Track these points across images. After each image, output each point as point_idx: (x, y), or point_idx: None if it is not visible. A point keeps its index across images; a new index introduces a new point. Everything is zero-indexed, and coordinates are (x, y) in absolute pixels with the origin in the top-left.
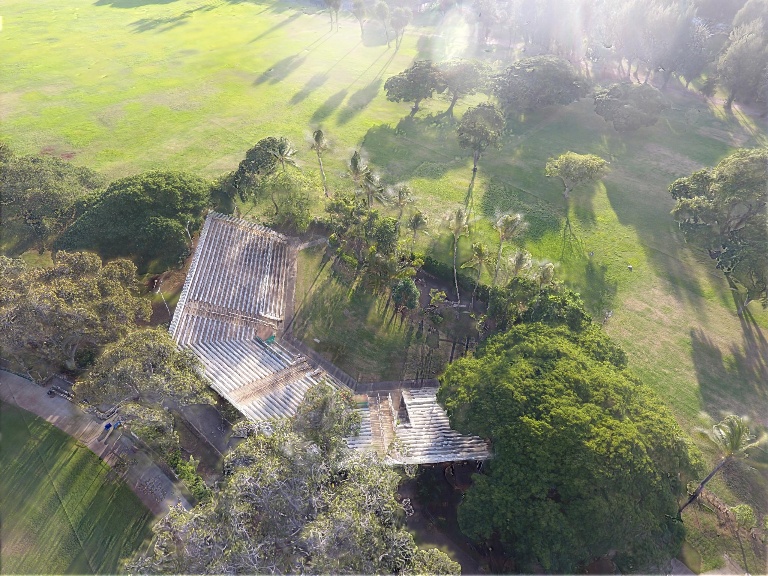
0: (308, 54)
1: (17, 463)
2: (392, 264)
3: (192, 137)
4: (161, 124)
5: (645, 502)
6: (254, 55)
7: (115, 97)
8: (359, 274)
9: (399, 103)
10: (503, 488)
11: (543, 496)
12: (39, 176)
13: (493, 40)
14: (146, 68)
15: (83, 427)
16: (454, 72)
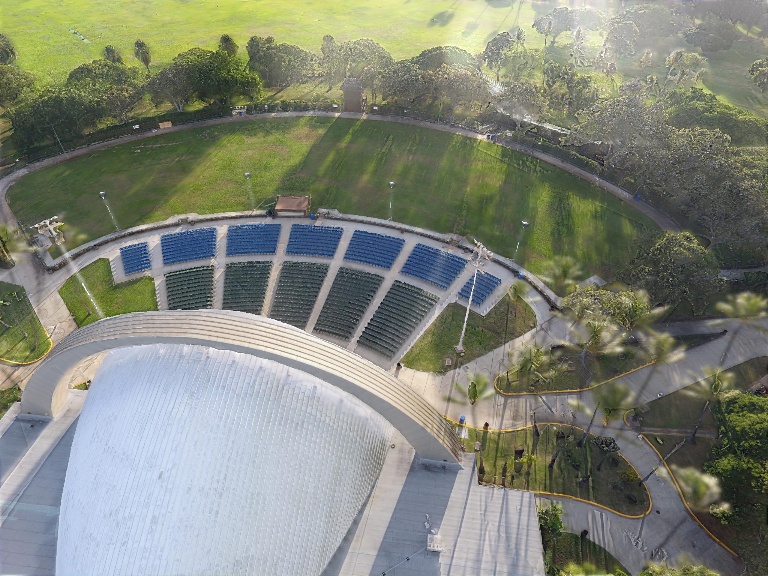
0: (454, 11)
1: (456, 144)
2: (594, 94)
3: (410, 52)
4: (383, 45)
5: (762, 139)
6: (414, 11)
7: (338, 31)
8: (565, 108)
9: (539, 39)
10: None
11: None
12: (377, 48)
13: (590, 6)
14: (343, 16)
15: (476, 136)
16: (584, 15)
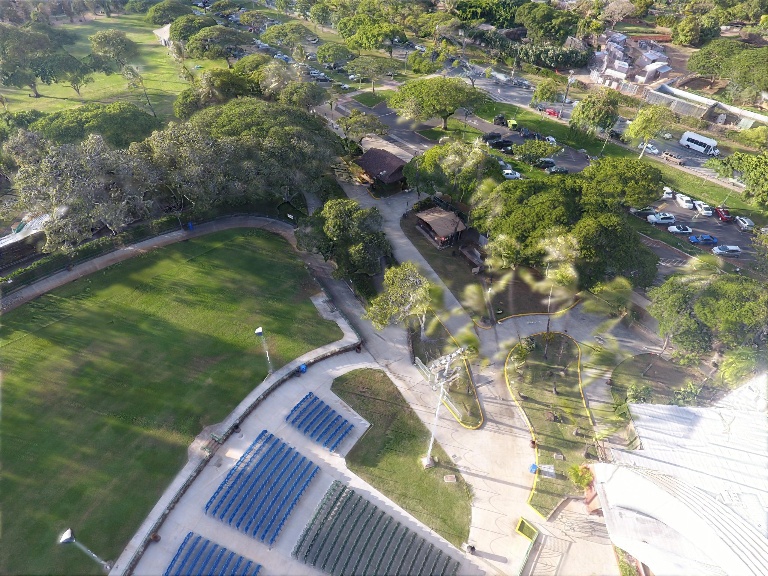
0: None
1: None
2: None
3: None
4: None
5: None
6: None
7: None
8: None
9: None
10: (116, 148)
11: (127, 136)
12: None
13: None
14: None
15: None
16: None
